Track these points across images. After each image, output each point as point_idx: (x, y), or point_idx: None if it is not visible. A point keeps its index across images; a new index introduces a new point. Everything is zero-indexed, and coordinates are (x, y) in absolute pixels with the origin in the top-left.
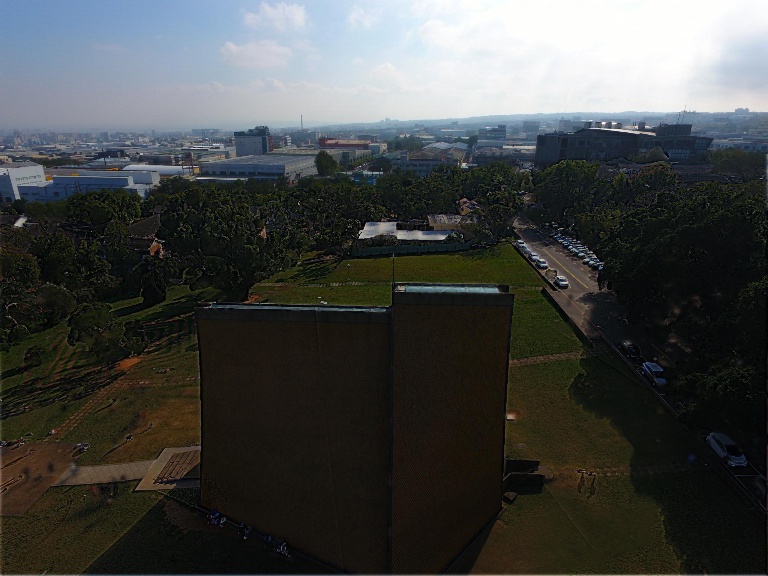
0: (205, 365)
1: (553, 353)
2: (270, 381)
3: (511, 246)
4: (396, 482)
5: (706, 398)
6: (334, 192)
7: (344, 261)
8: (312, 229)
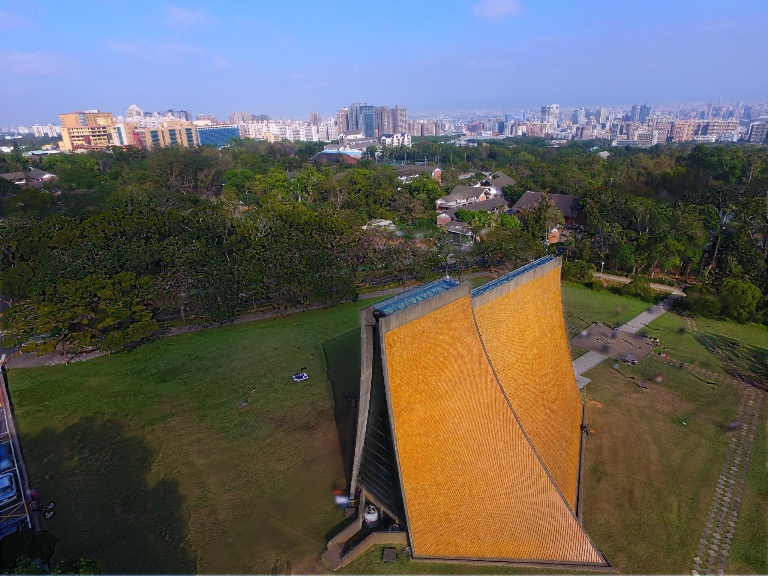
0: None
1: None
2: None
3: None
4: None
5: None
6: None
7: None
8: None
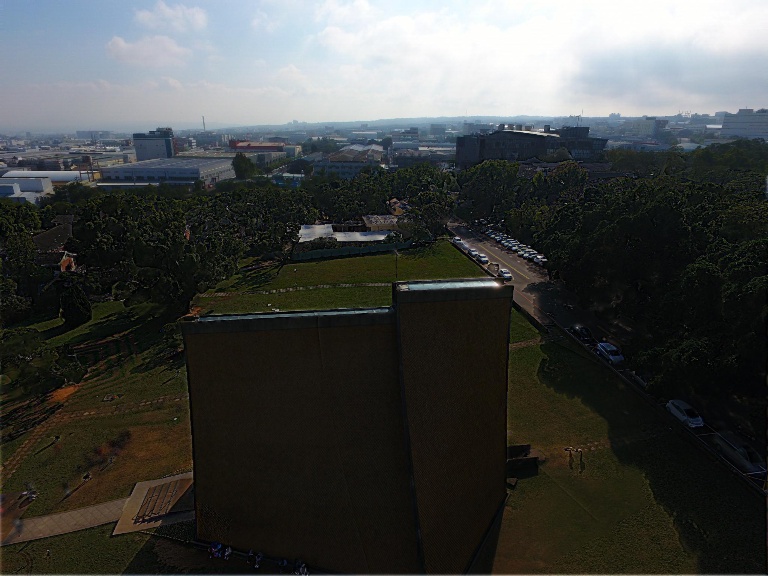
0: (194, 385)
1: (514, 342)
2: (270, 395)
3: (449, 243)
4: (418, 483)
5: (670, 369)
6: (264, 195)
7: (285, 266)
8: (244, 234)
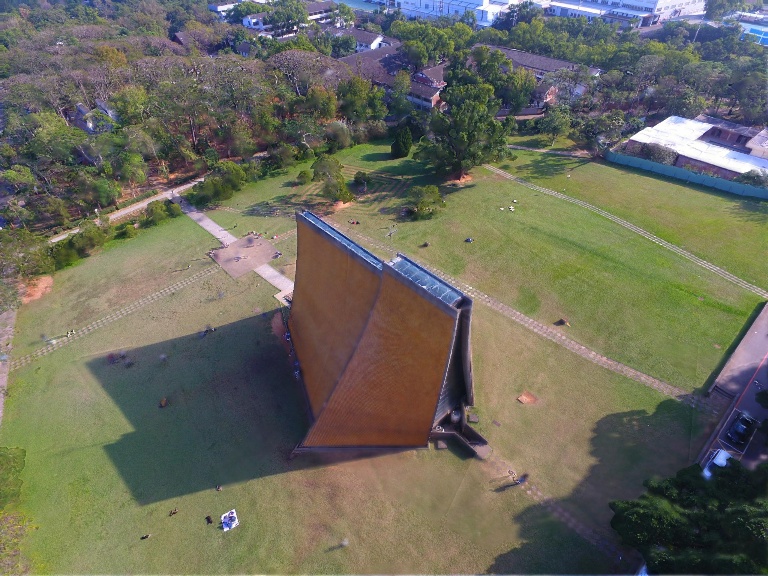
0: (299, 248)
1: (651, 375)
2: (323, 277)
3: None
4: (342, 382)
5: None
6: (652, 66)
7: (589, 164)
8: None
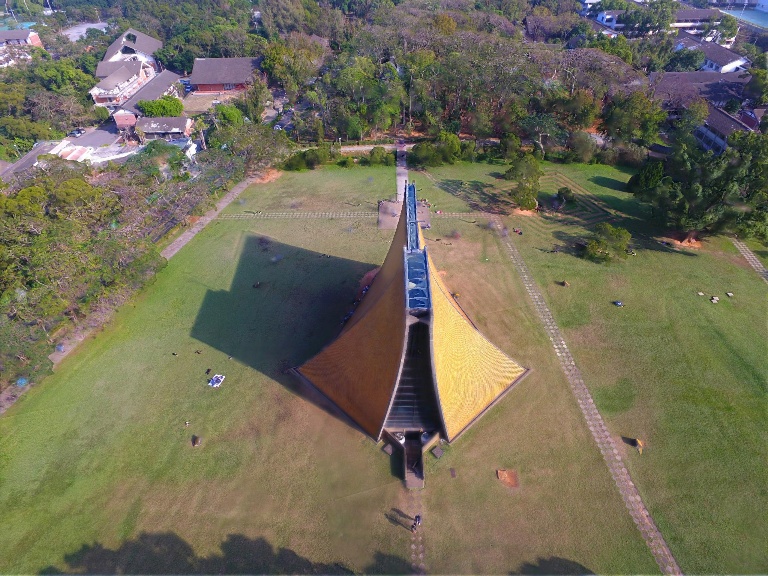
0: None
1: (686, 575)
2: None
3: None
4: (343, 337)
5: None
6: None
7: None
8: None
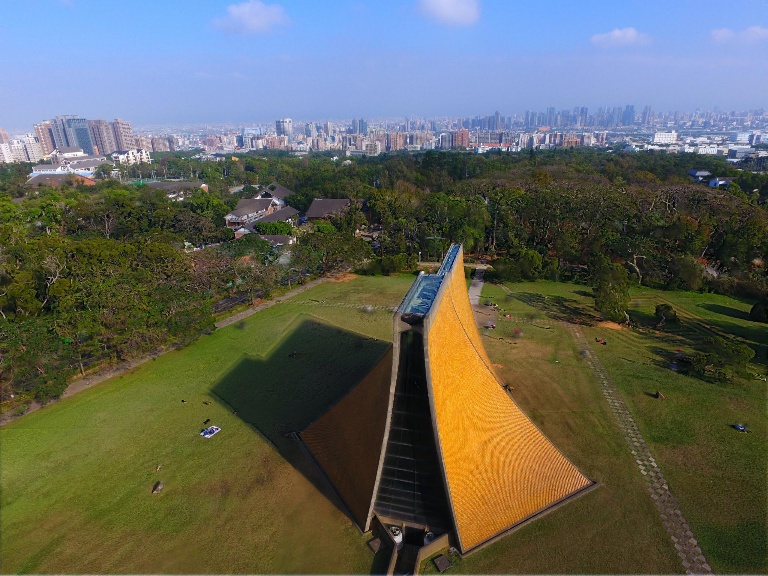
0: None
1: None
2: None
3: None
4: (351, 393)
5: None
6: None
7: None
8: None
